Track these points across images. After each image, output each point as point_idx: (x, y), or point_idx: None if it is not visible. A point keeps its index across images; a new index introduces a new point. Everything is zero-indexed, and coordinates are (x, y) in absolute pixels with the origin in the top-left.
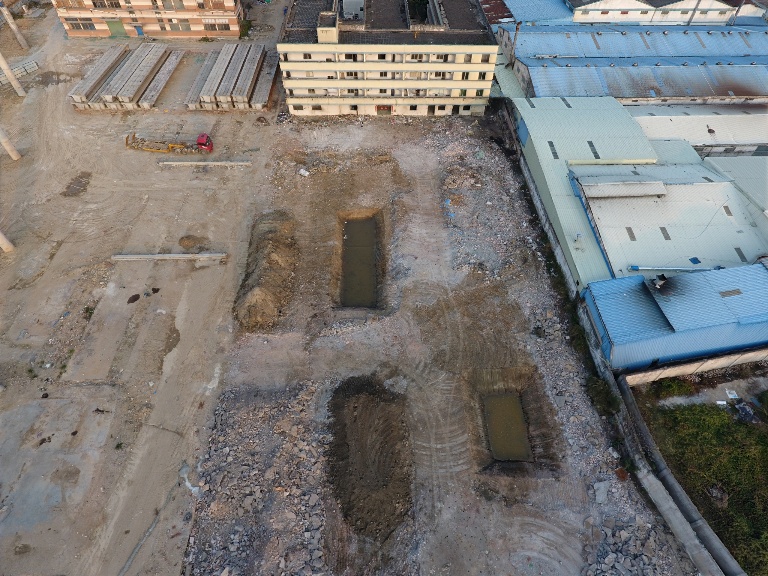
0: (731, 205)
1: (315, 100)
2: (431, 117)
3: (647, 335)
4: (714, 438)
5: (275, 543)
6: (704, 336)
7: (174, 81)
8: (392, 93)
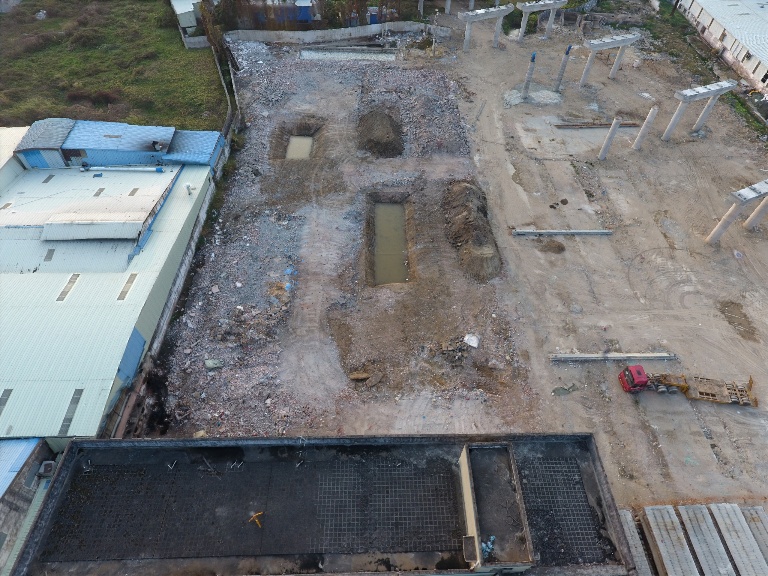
0: None
1: None
2: None
3: (195, 132)
4: None
5: None
6: None
7: None
8: None
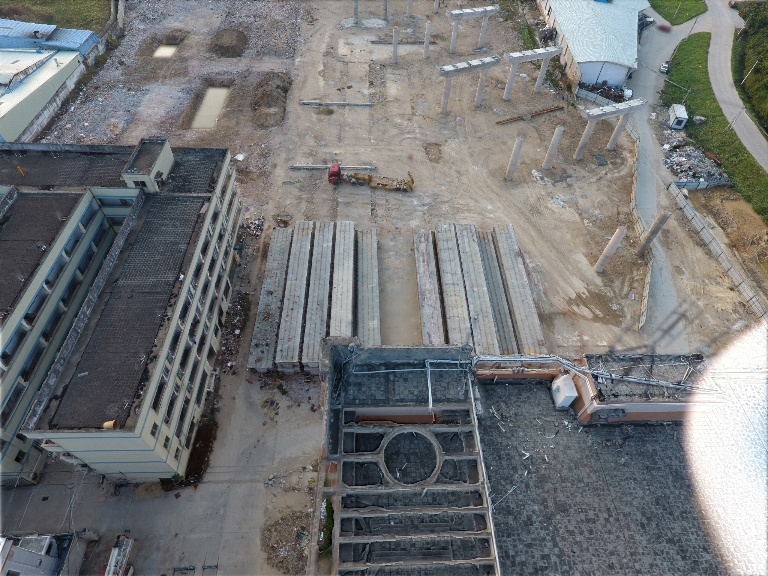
0: None
1: None
2: None
3: None
4: None
5: None
6: None
7: None
8: None
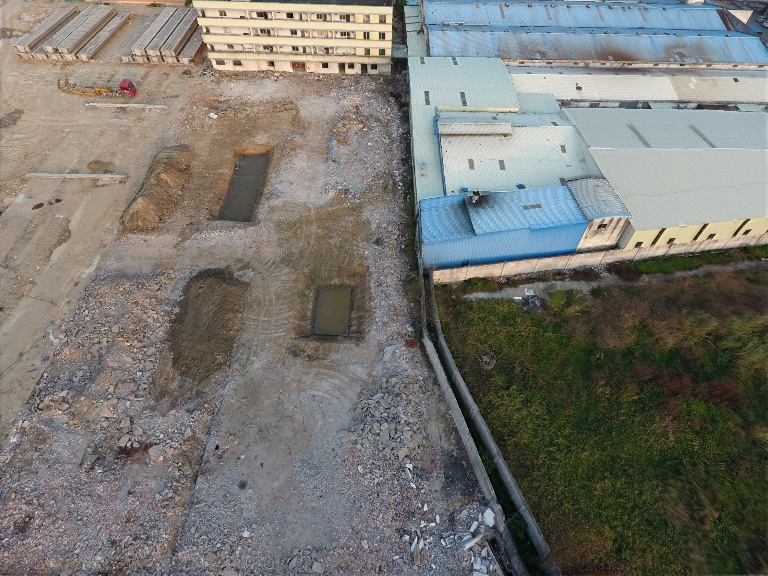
0: (567, 144)
1: (233, 55)
2: (342, 75)
3: (453, 237)
4: (499, 321)
5: (108, 375)
6: (504, 241)
7: (116, 39)
8: (304, 51)
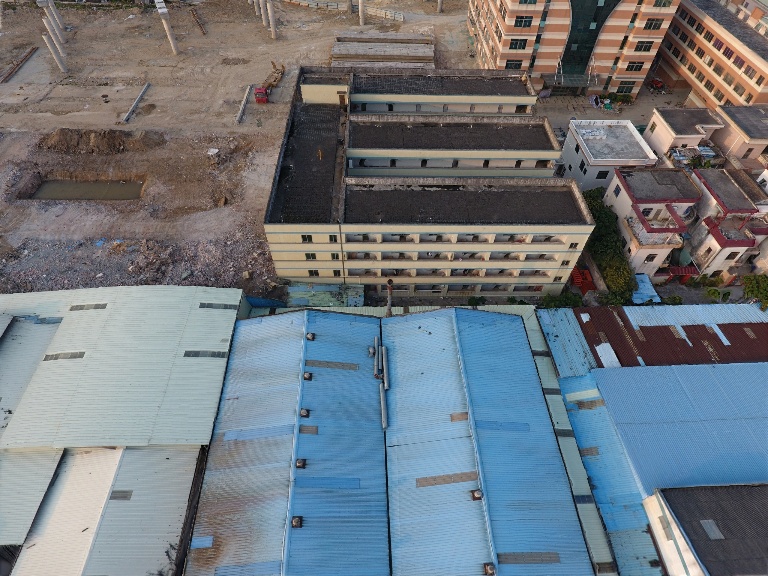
0: None
1: None
2: None
3: None
4: None
5: None
6: None
7: None
8: None
